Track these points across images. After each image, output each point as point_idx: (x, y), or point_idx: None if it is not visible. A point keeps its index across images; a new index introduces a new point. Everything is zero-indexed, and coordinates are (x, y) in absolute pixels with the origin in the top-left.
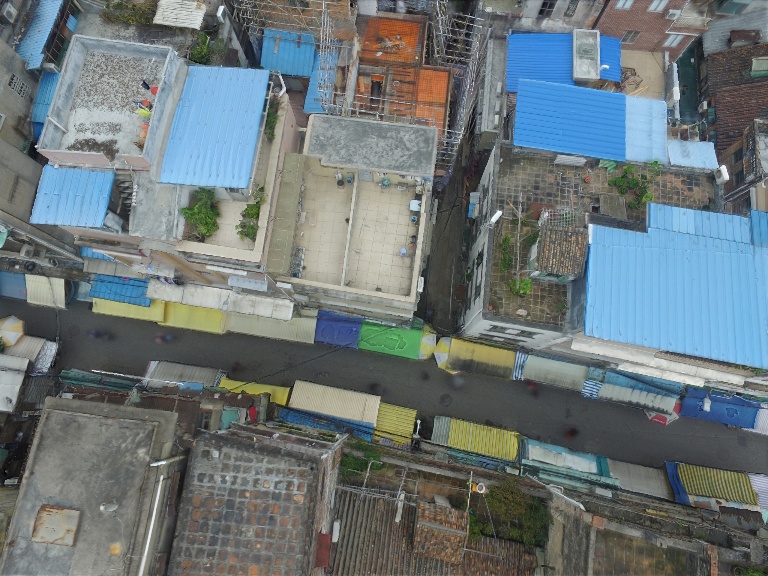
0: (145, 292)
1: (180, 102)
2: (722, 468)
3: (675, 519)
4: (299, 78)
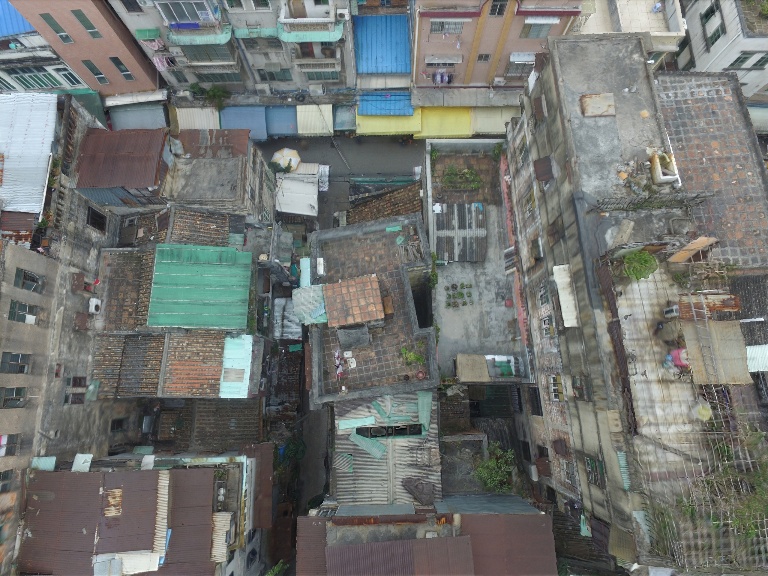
0: (407, 104)
1: None
2: None
3: None
4: None
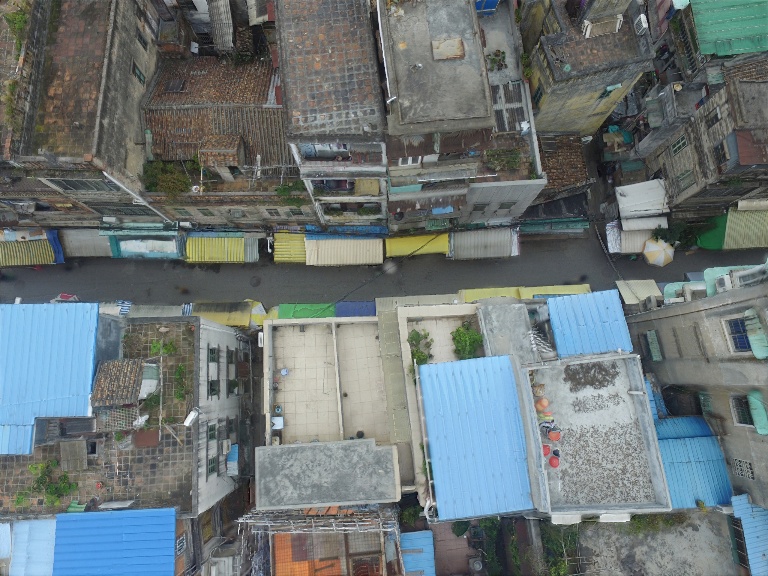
0: None
1: (525, 456)
2: (22, 275)
3: (49, 201)
4: None
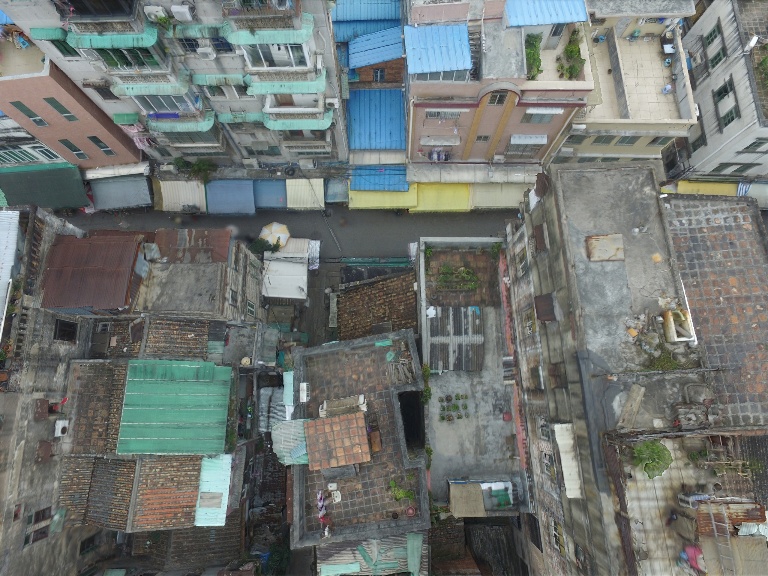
0: (402, 179)
1: None
2: None
3: None
4: None
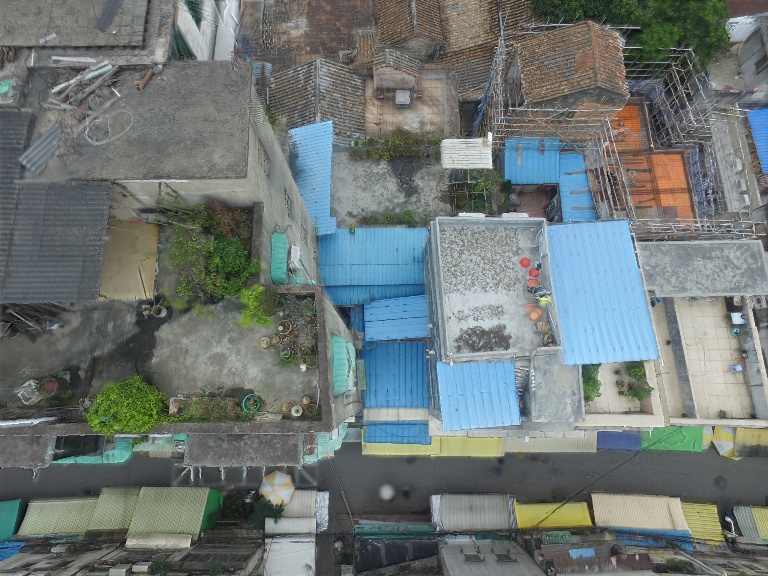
0: (423, 429)
1: None
2: None
3: None
4: (544, 185)
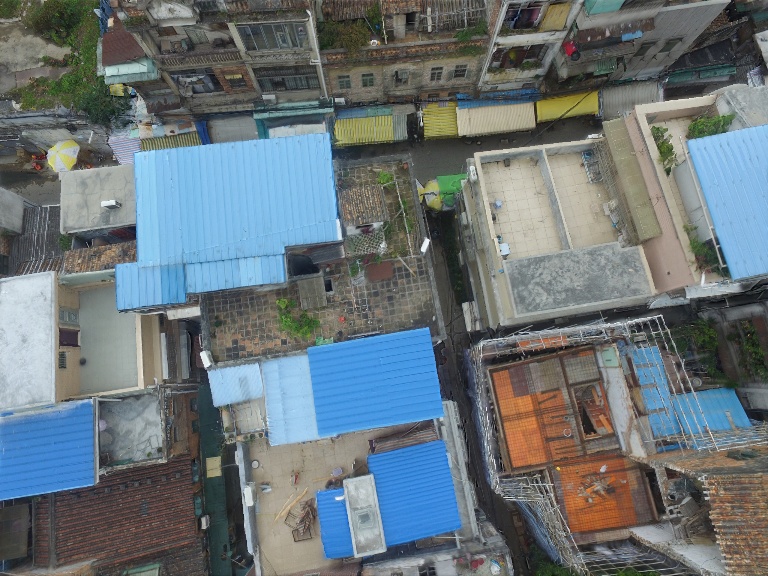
0: None
1: None
2: None
3: (221, 71)
4: None
